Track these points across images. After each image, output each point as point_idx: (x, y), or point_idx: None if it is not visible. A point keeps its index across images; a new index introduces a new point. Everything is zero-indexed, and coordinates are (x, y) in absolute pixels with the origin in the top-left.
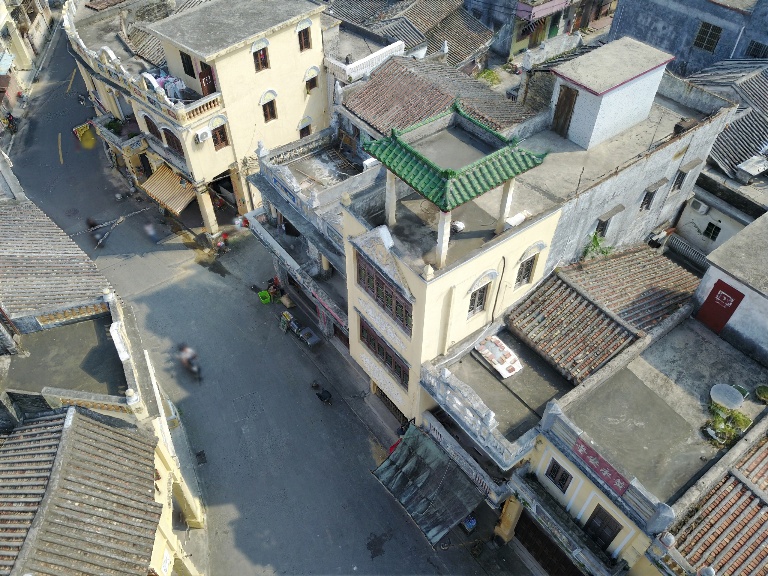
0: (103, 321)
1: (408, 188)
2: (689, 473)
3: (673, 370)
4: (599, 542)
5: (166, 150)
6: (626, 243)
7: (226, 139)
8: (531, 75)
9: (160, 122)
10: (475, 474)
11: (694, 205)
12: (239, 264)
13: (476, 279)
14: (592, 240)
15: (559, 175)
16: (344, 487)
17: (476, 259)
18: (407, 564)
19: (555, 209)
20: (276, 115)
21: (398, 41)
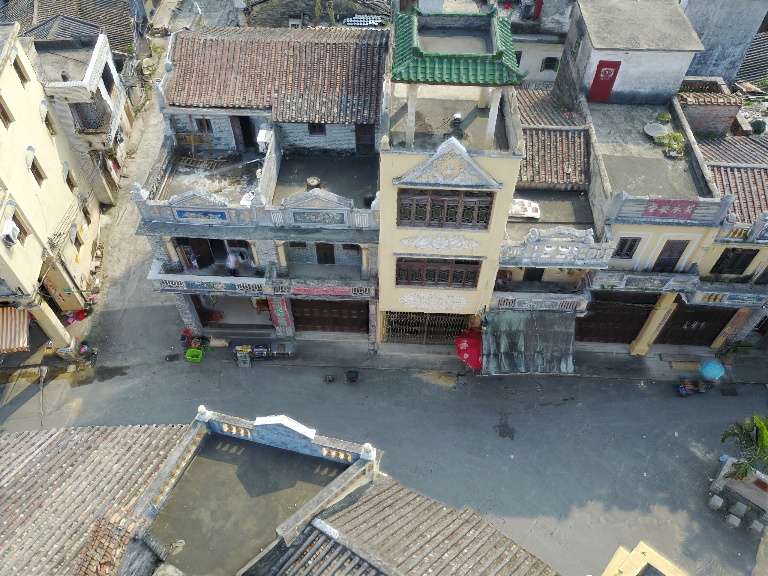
0: (209, 447)
1: None
2: (691, 182)
3: (616, 137)
4: (666, 270)
5: None
6: None
7: (22, 228)
8: (249, 12)
9: None
10: (560, 303)
11: None
12: (125, 352)
13: None
14: None
15: None
16: (441, 420)
17: None
18: (534, 420)
19: None
20: (42, 175)
21: (99, 35)
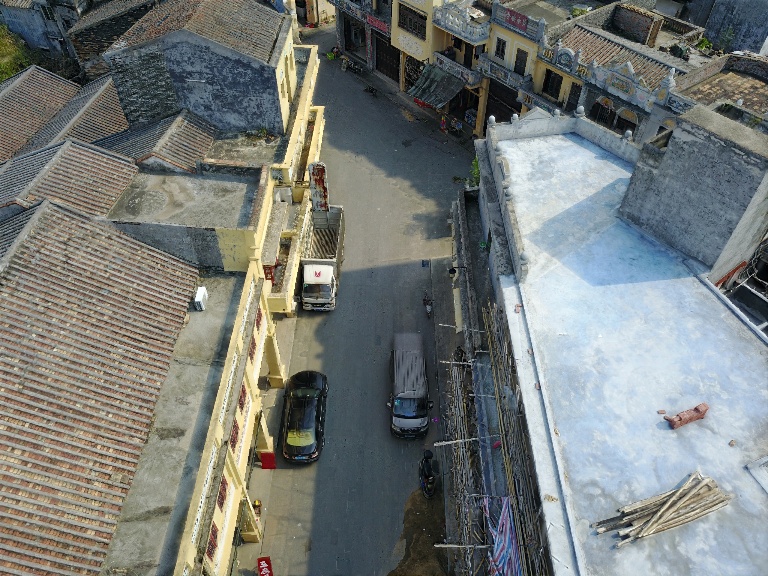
0: (263, 3)
1: None
2: None
3: (558, 4)
4: None
5: None
6: None
7: None
8: None
9: None
10: (461, 73)
11: None
12: None
13: None
14: None
15: None
16: (387, 125)
17: None
18: (424, 149)
19: None
20: None
21: None
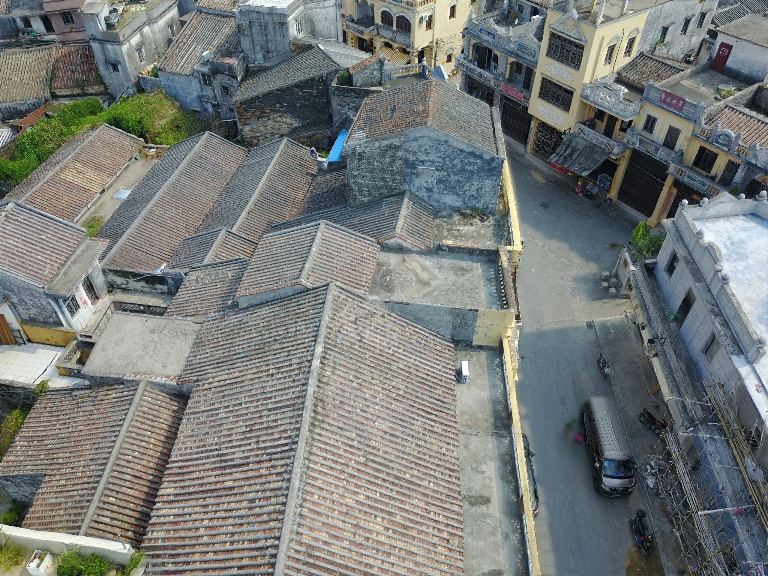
0: (418, 77)
1: (573, 7)
2: None
3: (701, 83)
4: None
5: (395, 31)
6: (673, 55)
7: (431, 25)
8: None
9: (397, 12)
10: (605, 143)
11: (708, 48)
12: None
13: (612, 37)
14: (659, 39)
15: (643, 6)
16: (522, 187)
17: (614, 24)
18: (562, 211)
19: (647, 9)
20: (454, 15)
21: None
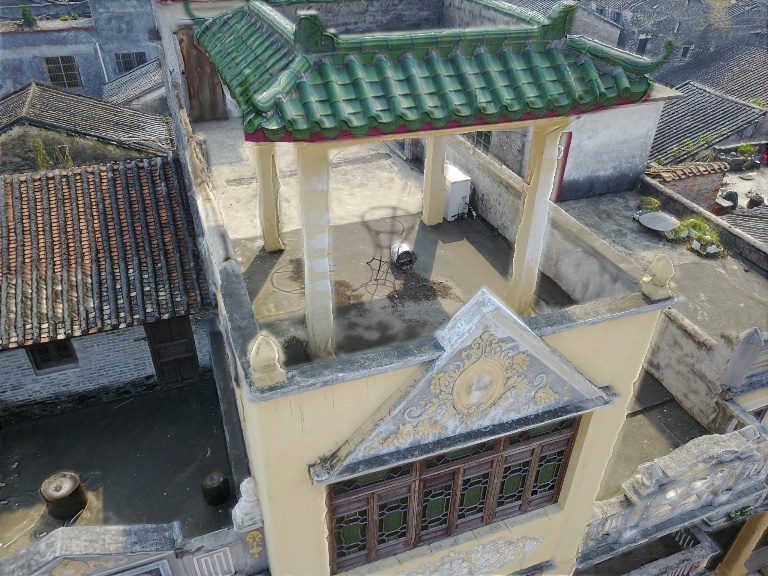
0: None
1: None
2: None
3: None
4: None
5: None
6: None
7: None
8: None
9: None
10: None
11: None
12: None
13: None
14: None
15: None
16: None
17: None
18: None
19: None
20: None
21: None
